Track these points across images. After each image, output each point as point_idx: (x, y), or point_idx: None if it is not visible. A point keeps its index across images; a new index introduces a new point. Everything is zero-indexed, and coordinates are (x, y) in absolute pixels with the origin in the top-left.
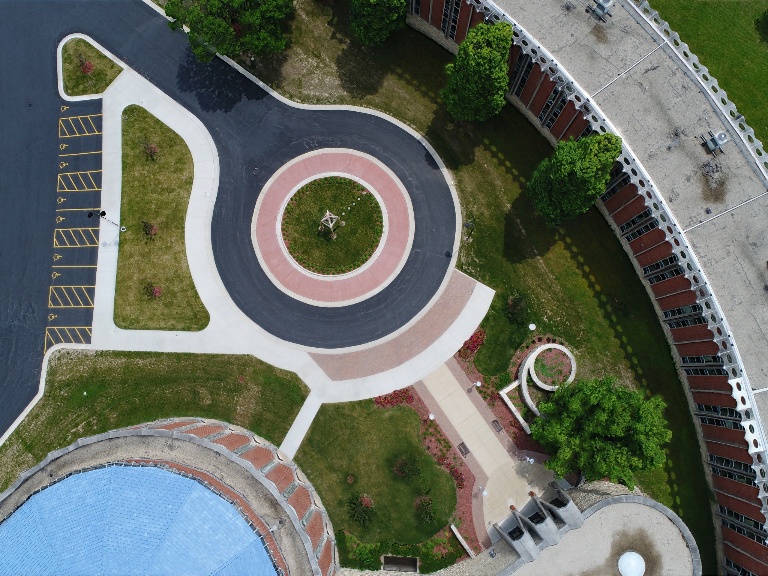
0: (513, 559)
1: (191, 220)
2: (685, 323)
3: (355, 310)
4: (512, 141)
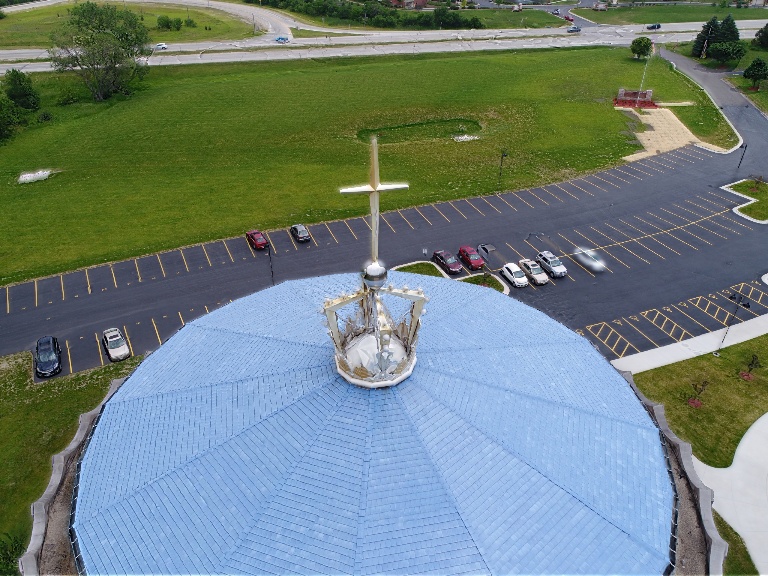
0: None
1: None
2: None
3: None
4: None
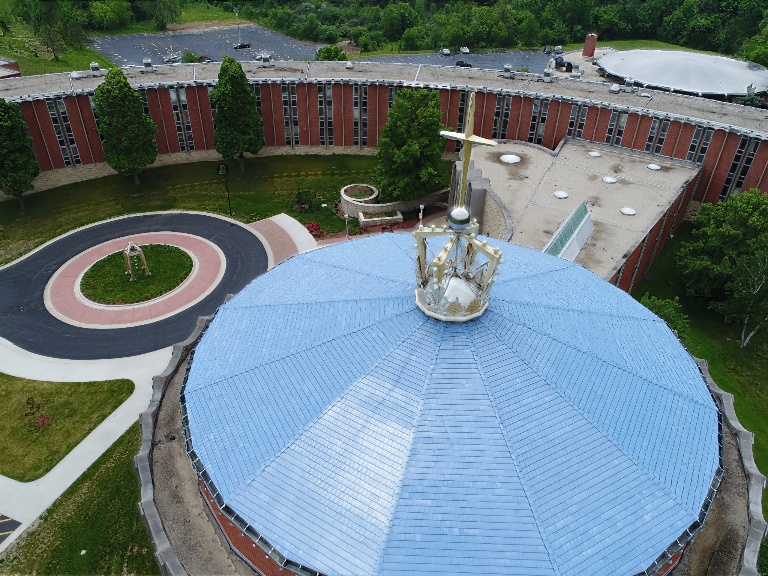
0: (487, 199)
1: (4, 366)
2: (364, 122)
3: (228, 280)
4: (183, 176)
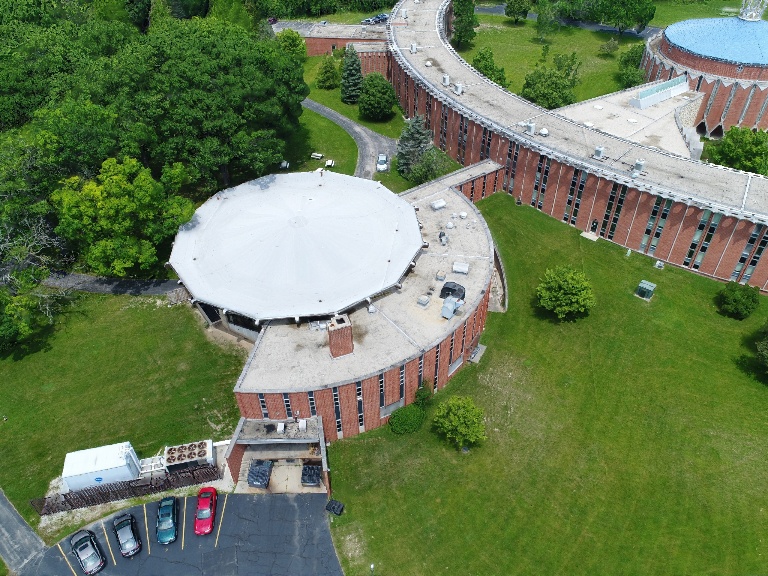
0: None
1: None
2: None
3: None
4: None
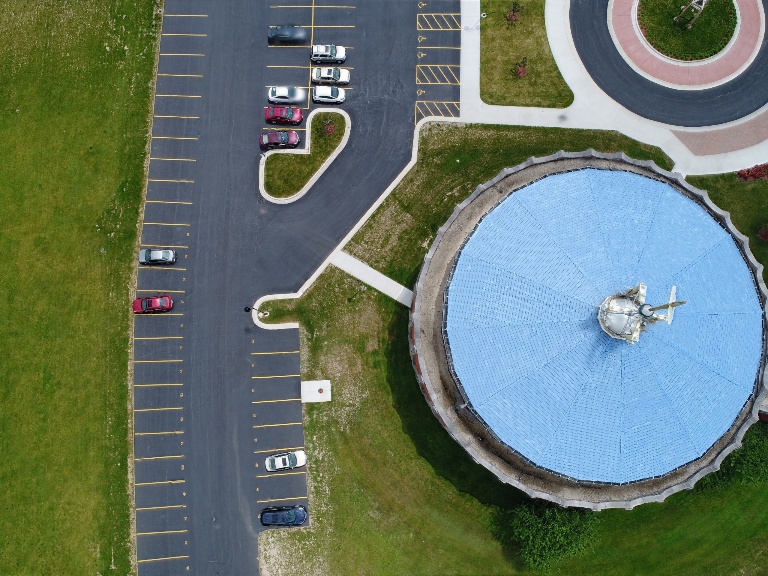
0: None
1: (550, 8)
2: None
3: (712, 93)
4: None
